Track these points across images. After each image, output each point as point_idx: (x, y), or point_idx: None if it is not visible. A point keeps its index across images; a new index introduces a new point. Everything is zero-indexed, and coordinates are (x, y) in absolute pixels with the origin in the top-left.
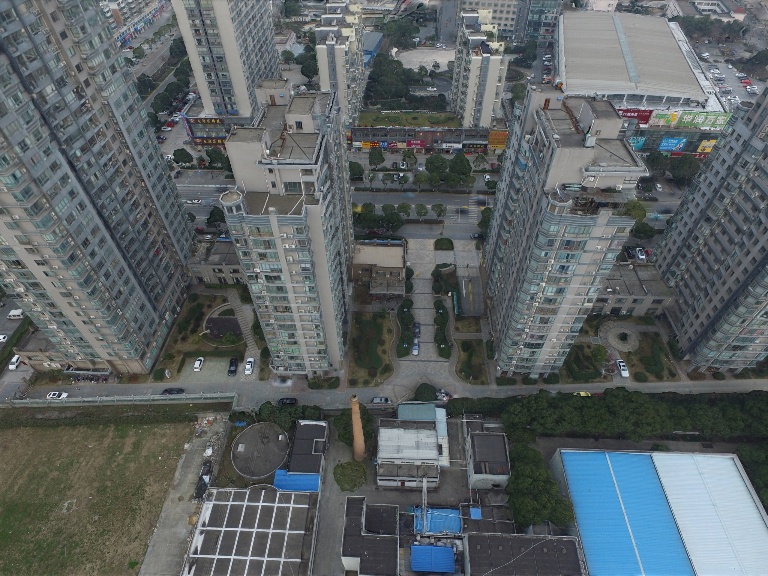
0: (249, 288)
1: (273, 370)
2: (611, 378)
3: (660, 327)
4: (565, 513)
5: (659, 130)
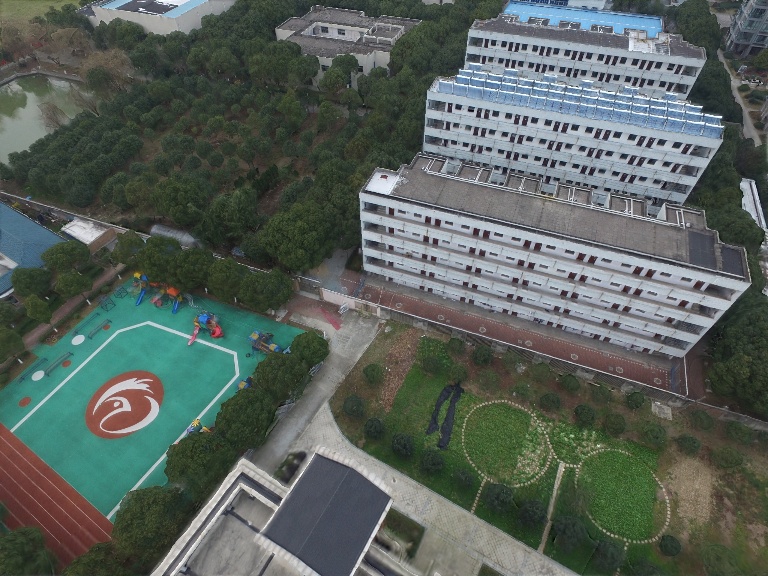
0: None
1: None
2: (738, 78)
3: None
4: None
5: None
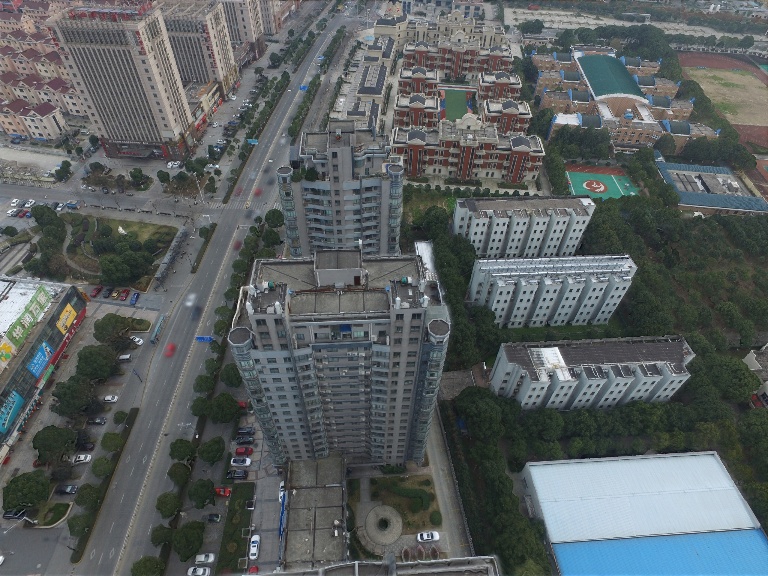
0: None
1: None
2: (442, 554)
3: (361, 475)
4: None
5: (14, 371)
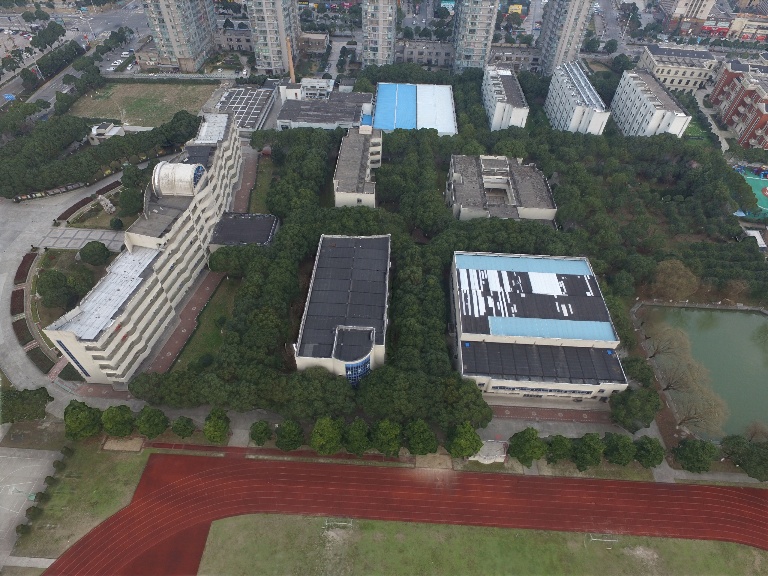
0: (247, 5)
1: (256, 67)
2: None
3: None
4: (370, 87)
5: None
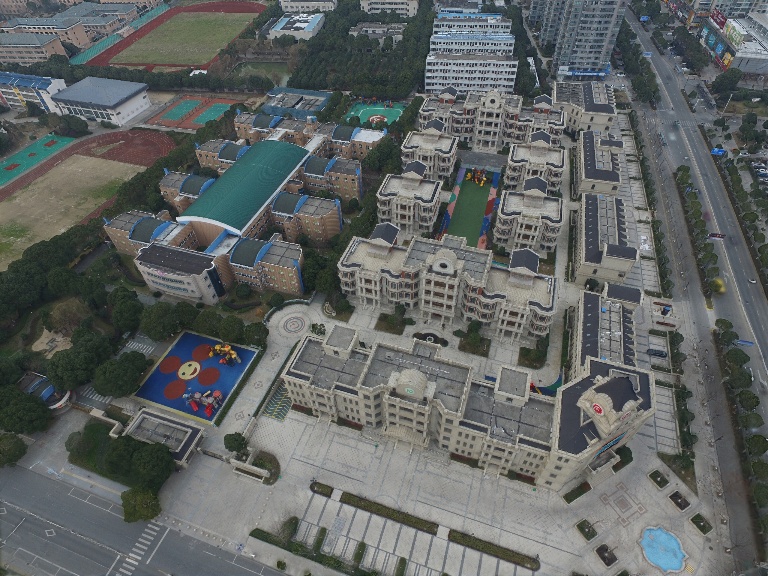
0: None
1: None
2: None
3: None
4: (483, 6)
5: (720, 34)
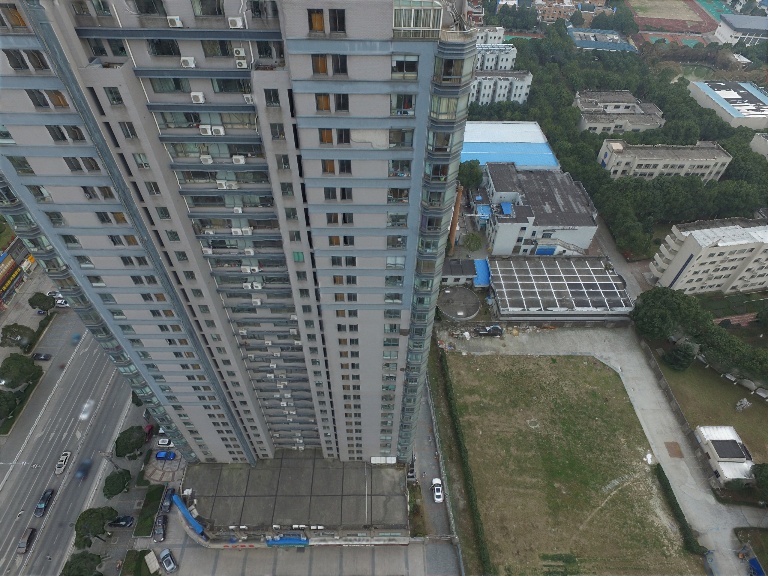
0: None
1: None
2: None
3: None
4: None
5: None
